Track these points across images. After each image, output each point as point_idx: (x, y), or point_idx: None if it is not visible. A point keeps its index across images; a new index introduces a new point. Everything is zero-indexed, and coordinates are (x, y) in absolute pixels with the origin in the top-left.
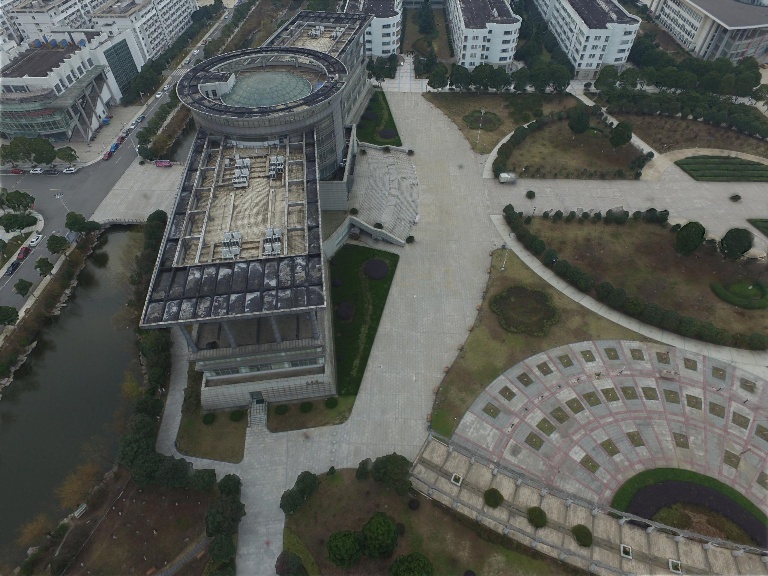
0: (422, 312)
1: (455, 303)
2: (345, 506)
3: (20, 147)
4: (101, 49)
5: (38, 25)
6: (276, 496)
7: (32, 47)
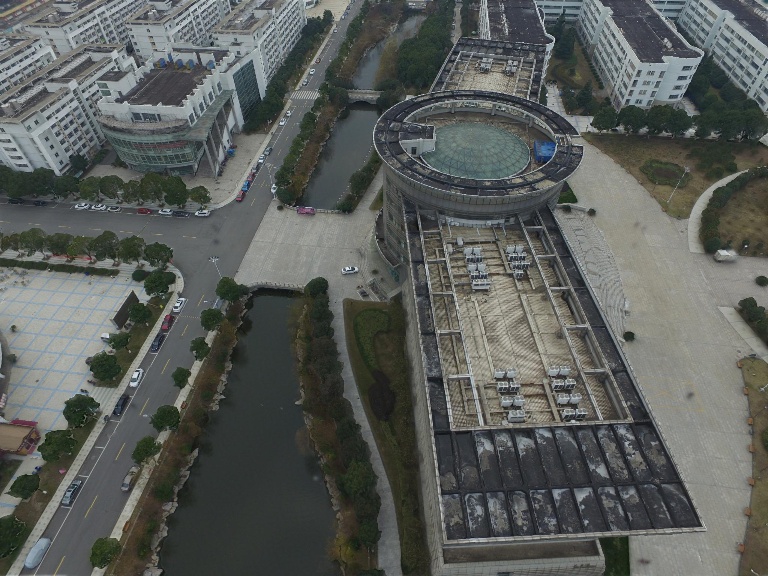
0: (677, 449)
1: (716, 438)
2: None
3: (152, 186)
4: (231, 72)
5: (152, 38)
6: None
7: (156, 67)
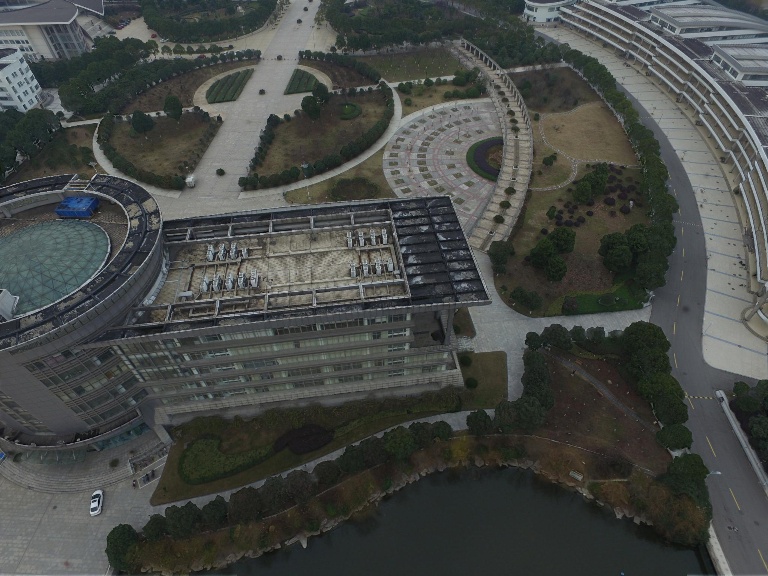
0: None
1: None
2: (522, 285)
3: None
4: None
5: None
6: (525, 325)
7: None
